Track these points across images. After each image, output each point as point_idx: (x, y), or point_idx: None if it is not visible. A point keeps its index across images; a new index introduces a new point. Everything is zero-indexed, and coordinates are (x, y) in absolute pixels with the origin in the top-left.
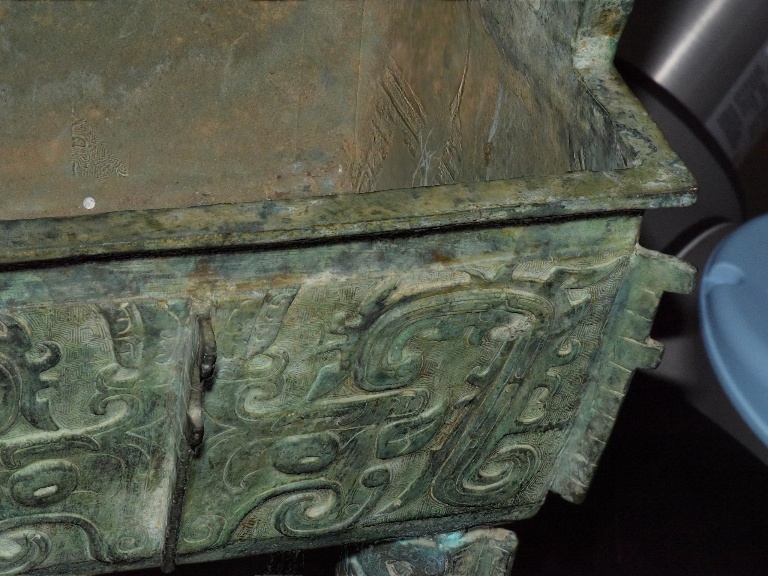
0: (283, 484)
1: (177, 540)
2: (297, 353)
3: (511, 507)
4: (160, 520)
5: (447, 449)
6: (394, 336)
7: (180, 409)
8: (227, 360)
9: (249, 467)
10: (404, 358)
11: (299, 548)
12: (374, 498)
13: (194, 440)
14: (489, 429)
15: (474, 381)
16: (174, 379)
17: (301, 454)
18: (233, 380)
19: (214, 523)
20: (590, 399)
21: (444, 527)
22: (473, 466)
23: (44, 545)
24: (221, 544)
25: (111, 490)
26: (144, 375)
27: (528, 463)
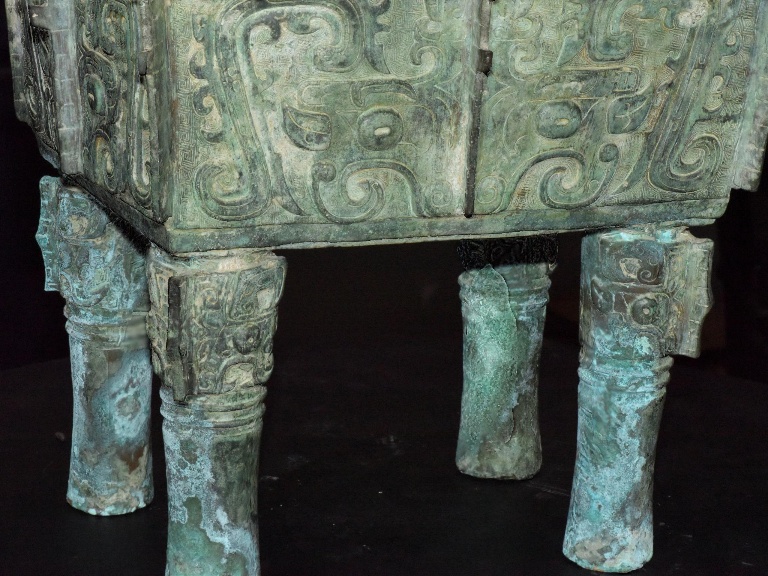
0: (544, 151)
1: (475, 181)
2: (548, 20)
3: (706, 203)
4: (460, 176)
5: (657, 133)
6: (613, 7)
7: (472, 59)
8: (501, 18)
9: (520, 130)
10: (621, 32)
11: (558, 227)
12: (609, 175)
13: (486, 64)
14: (685, 112)
15: (671, 64)
16: (466, 36)
17: (556, 115)
18: (506, 39)
19: (498, 184)
20: (753, 91)
21: (660, 218)
22: (676, 152)
23: (381, 192)
24: (504, 207)
25: (426, 144)
26: (446, 29)
27: (715, 151)
